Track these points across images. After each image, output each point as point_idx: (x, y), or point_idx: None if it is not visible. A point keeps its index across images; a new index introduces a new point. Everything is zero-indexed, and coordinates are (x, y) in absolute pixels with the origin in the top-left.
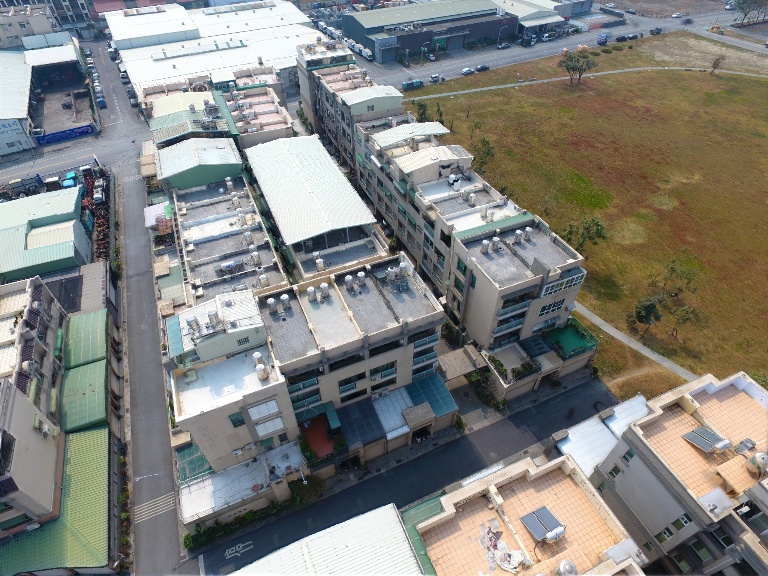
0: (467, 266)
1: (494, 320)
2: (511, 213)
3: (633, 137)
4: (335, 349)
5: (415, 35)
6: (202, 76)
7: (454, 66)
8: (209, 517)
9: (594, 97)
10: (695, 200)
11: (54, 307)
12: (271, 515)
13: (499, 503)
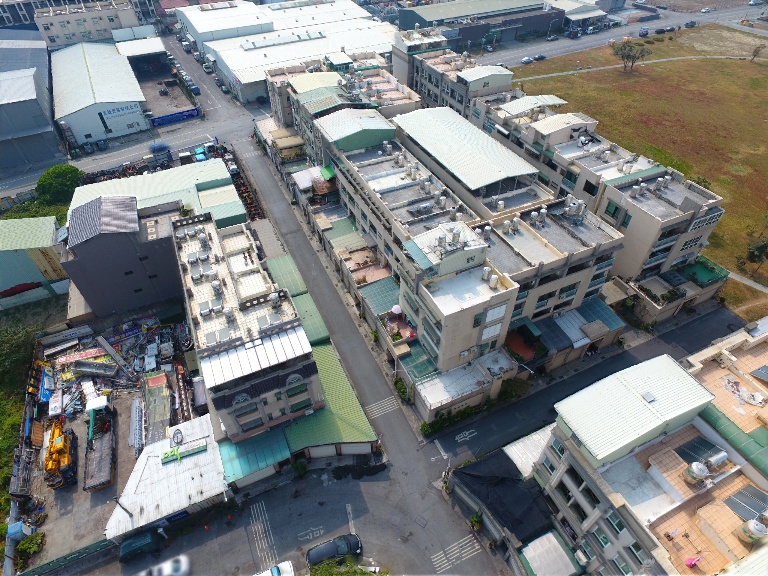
0: (622, 207)
1: (649, 252)
2: (642, 167)
3: (695, 116)
4: (547, 265)
5: (474, 27)
6: (314, 60)
7: (512, 56)
8: (446, 406)
9: (649, 82)
10: (766, 167)
11: None
12: (483, 411)
13: (734, 360)
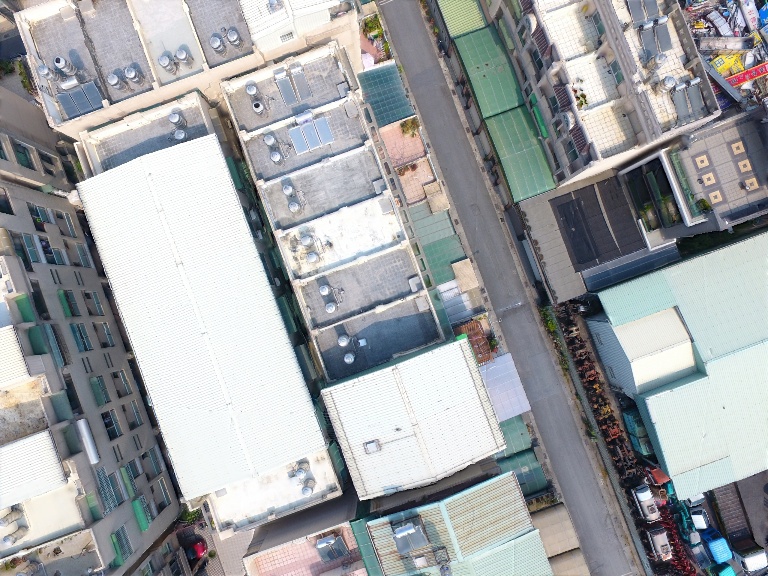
0: None
1: None
2: None
3: None
4: None
5: None
6: None
7: None
8: None
9: None
10: None
11: (566, 162)
12: None
13: None
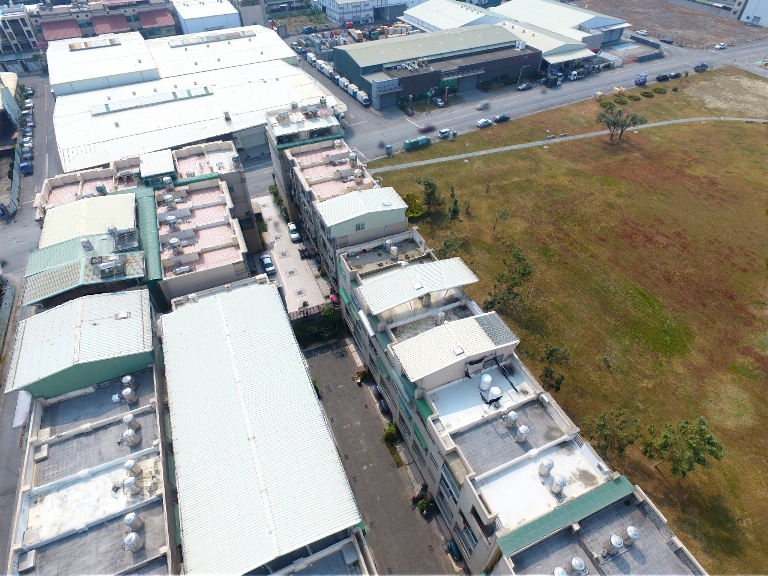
0: None
1: None
2: (589, 464)
3: (702, 226)
4: None
5: (420, 76)
6: (135, 157)
7: (467, 115)
8: None
9: (642, 161)
10: None
11: None
12: None
13: None
